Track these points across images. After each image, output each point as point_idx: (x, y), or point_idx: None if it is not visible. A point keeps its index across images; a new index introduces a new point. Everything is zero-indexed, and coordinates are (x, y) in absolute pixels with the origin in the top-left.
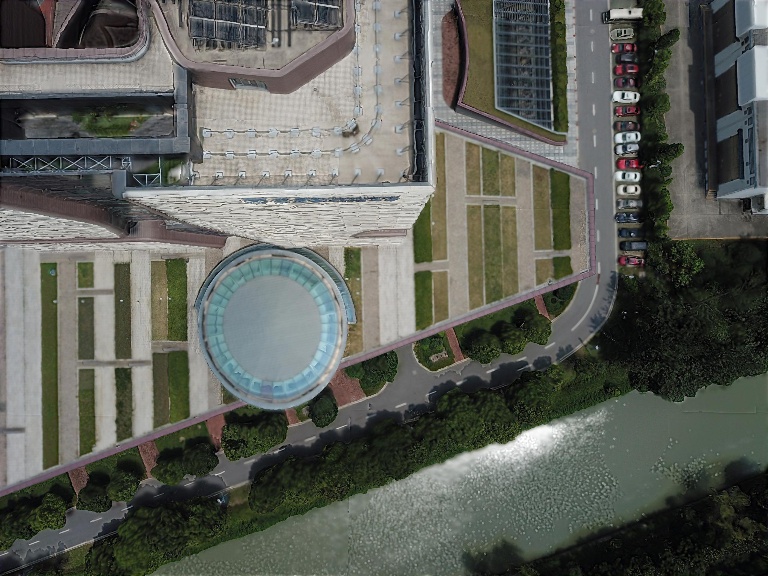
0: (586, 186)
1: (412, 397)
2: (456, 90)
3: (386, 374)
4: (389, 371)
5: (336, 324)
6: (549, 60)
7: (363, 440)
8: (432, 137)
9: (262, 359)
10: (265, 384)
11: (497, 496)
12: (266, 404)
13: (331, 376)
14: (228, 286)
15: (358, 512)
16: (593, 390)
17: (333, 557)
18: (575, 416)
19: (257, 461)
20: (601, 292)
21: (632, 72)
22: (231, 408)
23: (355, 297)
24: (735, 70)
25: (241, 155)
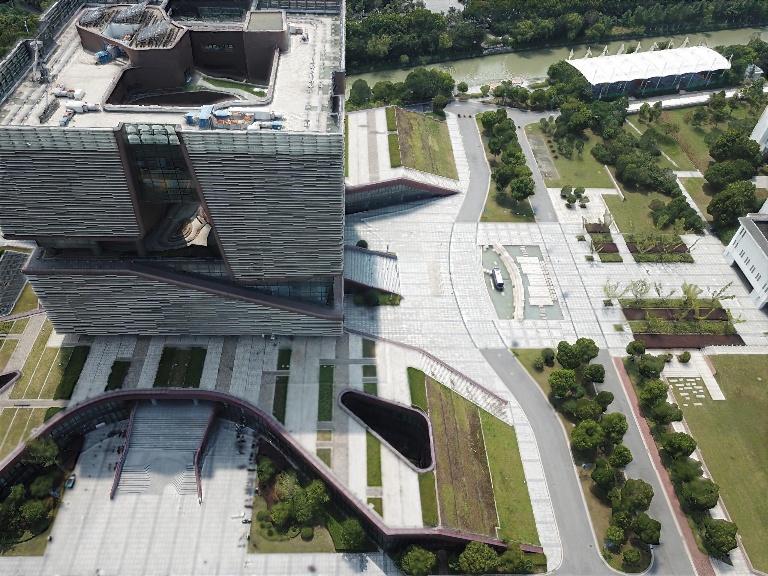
0: None
1: None
2: None
3: None
4: None
5: None
6: None
7: None
8: None
9: None
10: None
11: None
12: None
13: None
14: None
15: None
16: None
17: None
18: None
19: None
20: None
21: None
22: None
23: None
24: None
25: None
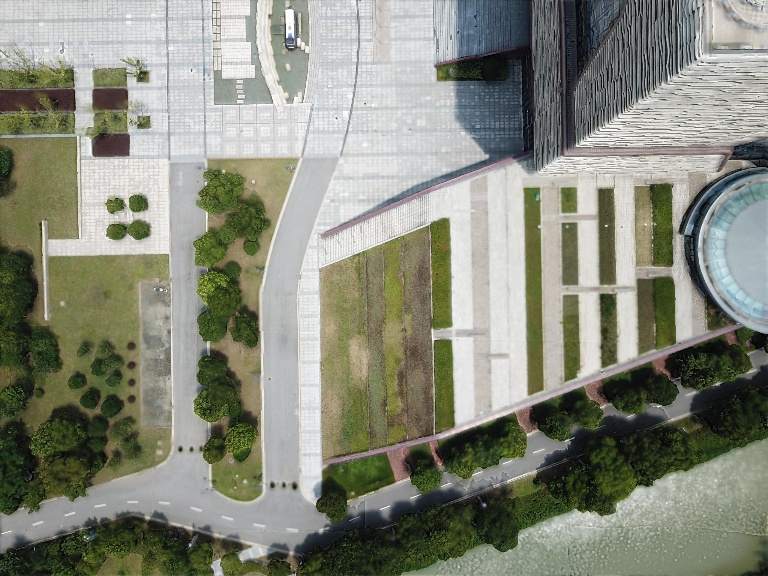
0: None
1: None
2: None
3: None
4: None
5: None
6: None
7: None
8: None
9: (766, 283)
10: (765, 309)
11: None
12: (767, 329)
13: None
14: (729, 210)
15: None
16: None
17: (755, 492)
18: None
19: (699, 393)
20: None
21: None
22: (716, 335)
23: None
24: None
25: None
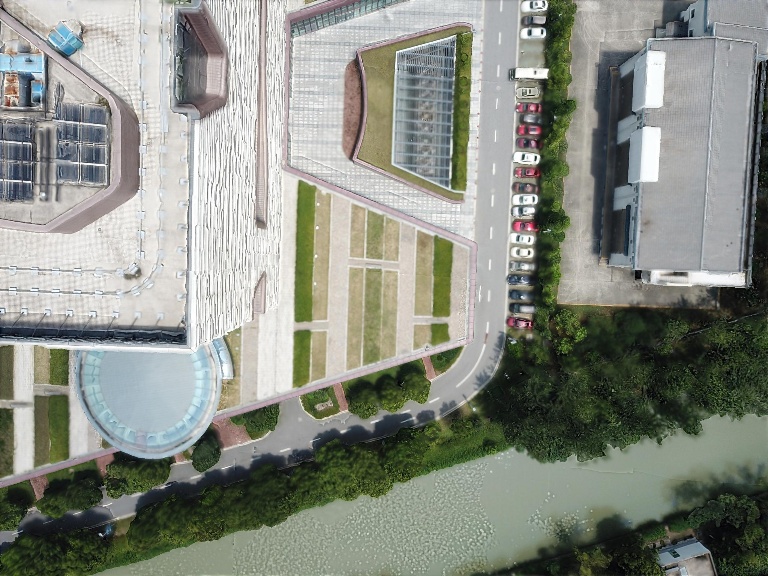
0: (469, 255)
1: (296, 443)
2: (356, 142)
3: (264, 426)
4: (267, 423)
5: (210, 380)
6: (451, 116)
7: (240, 486)
8: (192, 301)
9: (136, 411)
10: (140, 434)
11: (377, 537)
12: (140, 453)
13: (204, 430)
14: None
15: (243, 545)
16: (472, 446)
17: None
18: (456, 467)
19: (144, 495)
20: (488, 351)
21: (534, 134)
22: (109, 452)
23: (234, 352)
24: (629, 144)
25: (24, 291)
